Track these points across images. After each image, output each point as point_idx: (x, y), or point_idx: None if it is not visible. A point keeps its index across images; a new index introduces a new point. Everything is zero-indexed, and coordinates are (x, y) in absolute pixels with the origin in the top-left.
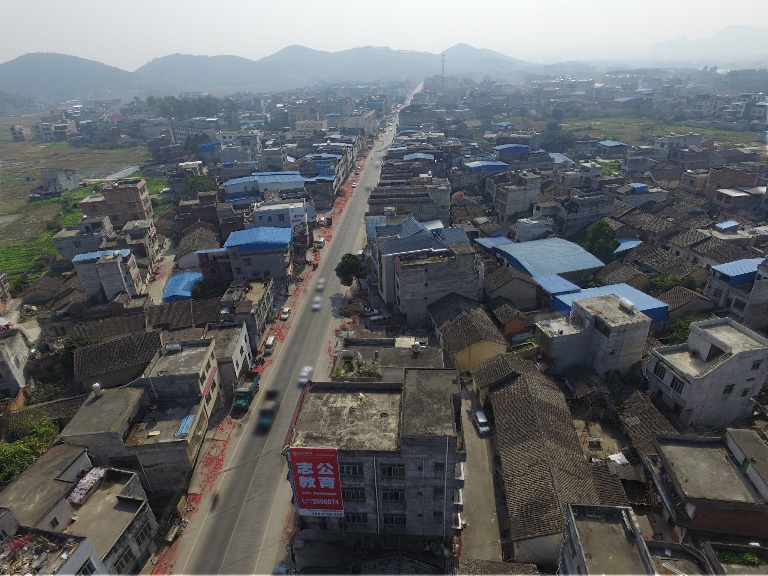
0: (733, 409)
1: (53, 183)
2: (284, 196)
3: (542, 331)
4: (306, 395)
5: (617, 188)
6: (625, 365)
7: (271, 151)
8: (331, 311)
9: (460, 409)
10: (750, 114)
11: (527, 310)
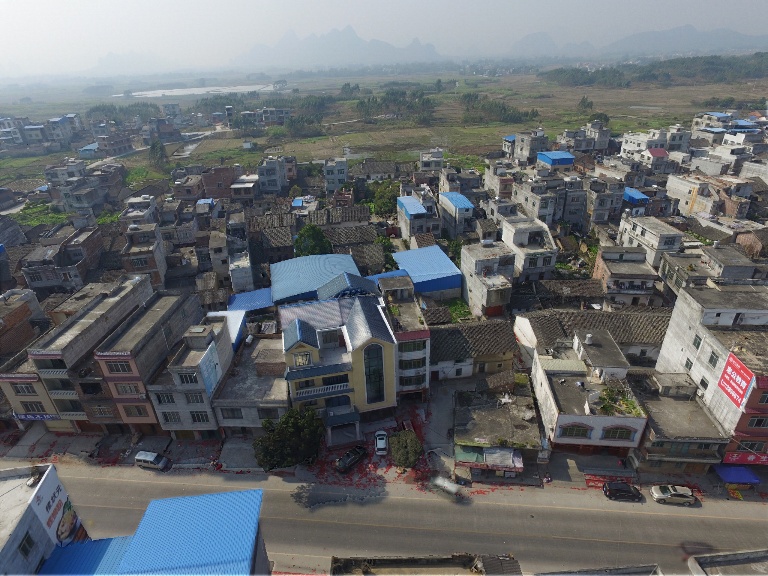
0: None
1: None
2: None
3: (501, 289)
4: None
5: (195, 210)
6: None
7: None
8: (360, 500)
9: None
10: (28, 138)
11: None
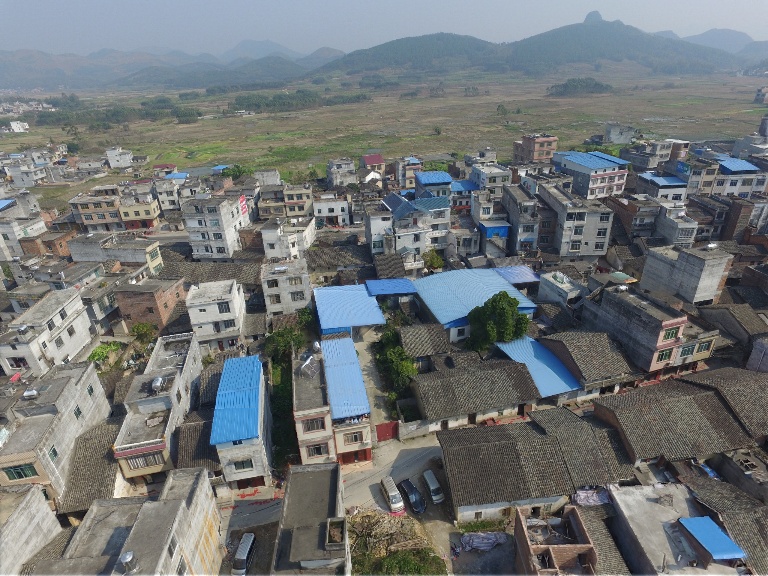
0: None
1: (608, 135)
2: (556, 173)
3: None
4: (237, 196)
5: None
6: None
7: (756, 148)
8: None
9: (203, 212)
10: None
11: None
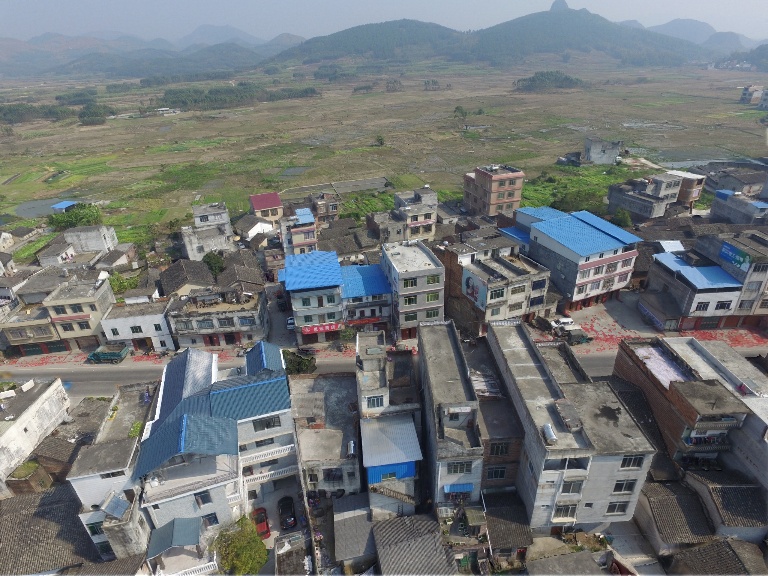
0: None
1: (587, 152)
2: (521, 257)
3: None
4: None
5: None
6: None
7: None
8: None
9: None
10: None
11: None
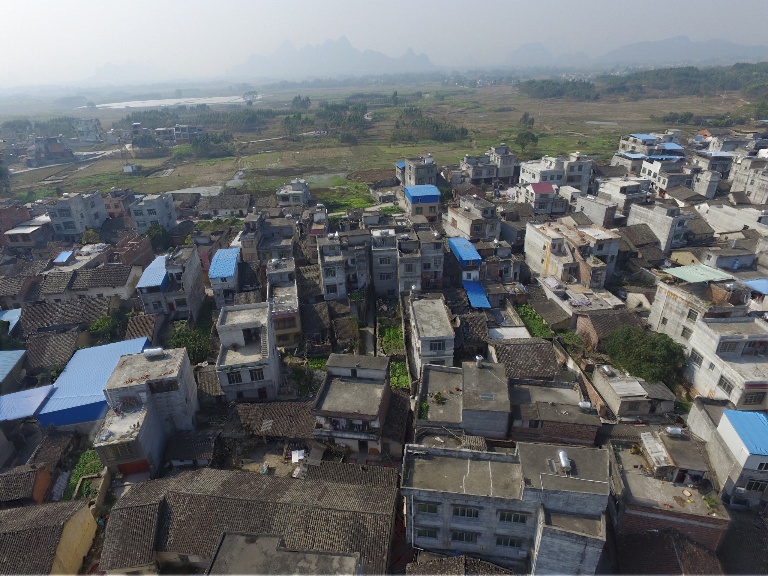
0: (277, 363)
1: None
2: None
3: (115, 444)
4: None
5: None
6: (195, 402)
7: None
8: None
9: None
10: None
11: (9, 462)
